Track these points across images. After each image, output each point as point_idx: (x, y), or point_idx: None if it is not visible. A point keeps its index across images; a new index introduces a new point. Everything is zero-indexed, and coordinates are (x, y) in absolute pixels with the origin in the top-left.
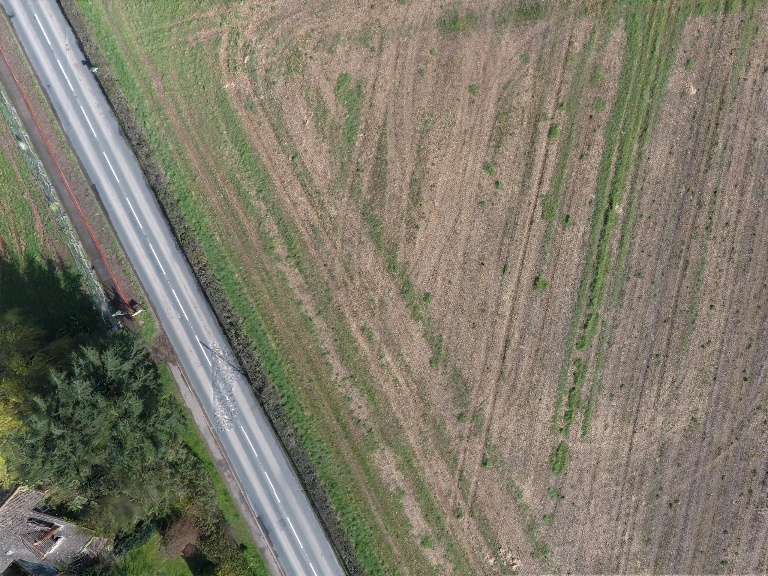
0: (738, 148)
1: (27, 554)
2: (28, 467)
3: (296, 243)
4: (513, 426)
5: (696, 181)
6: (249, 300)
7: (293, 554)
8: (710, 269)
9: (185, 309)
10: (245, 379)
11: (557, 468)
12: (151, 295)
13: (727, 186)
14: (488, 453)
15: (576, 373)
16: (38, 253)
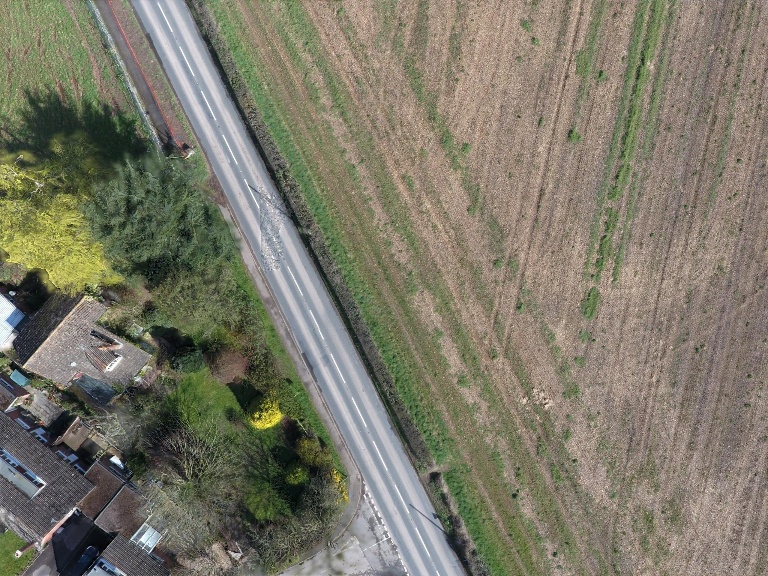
0: (766, 9)
1: (89, 368)
2: (111, 227)
3: (340, 94)
4: (547, 272)
5: (725, 40)
6: (295, 147)
7: (336, 389)
8: (737, 125)
9: (235, 154)
10: (291, 222)
11: (588, 312)
12: (202, 140)
13: (755, 45)
14: (522, 297)
15: (607, 222)
16: (95, 99)
